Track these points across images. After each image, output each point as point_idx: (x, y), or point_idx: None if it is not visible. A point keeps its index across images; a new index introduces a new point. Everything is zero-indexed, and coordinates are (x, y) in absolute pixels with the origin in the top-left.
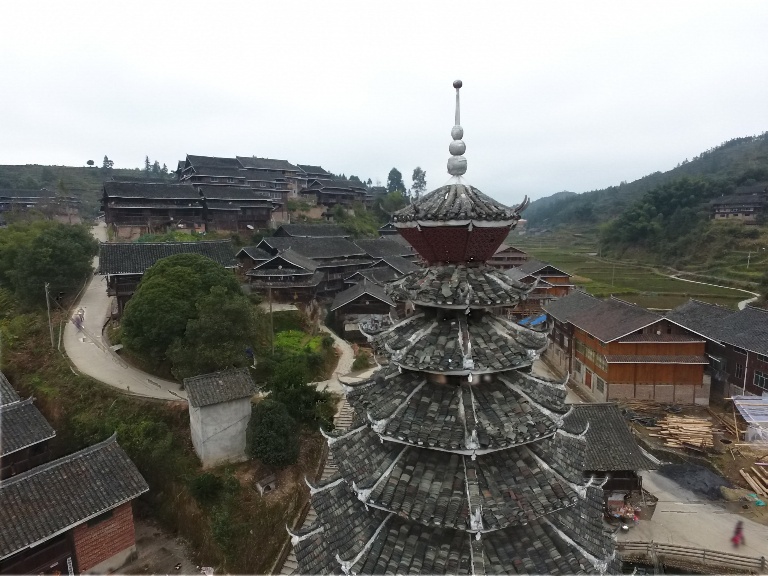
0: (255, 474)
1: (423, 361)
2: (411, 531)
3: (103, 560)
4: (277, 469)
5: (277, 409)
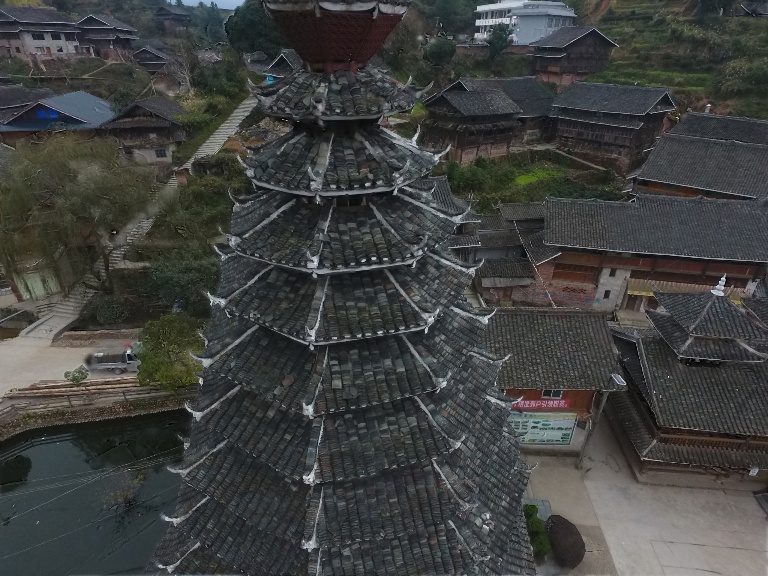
0: None
1: None
2: None
3: None
4: None
5: None
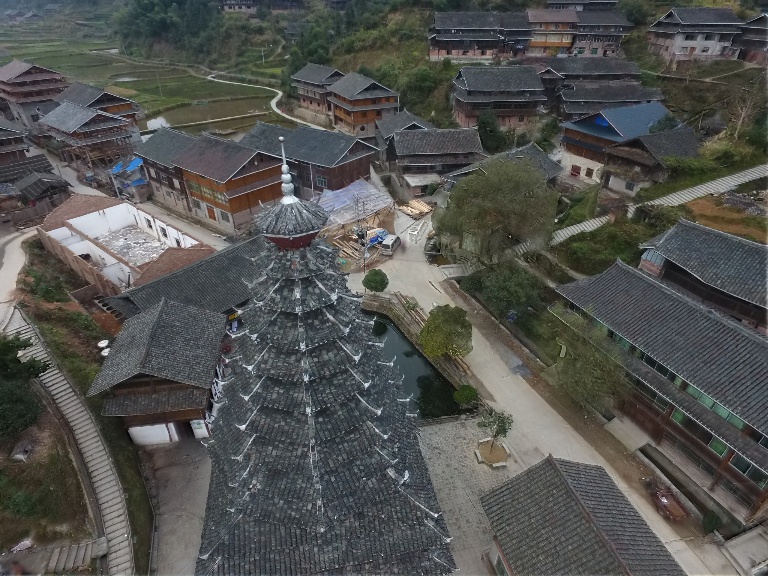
0: None
1: (313, 305)
2: (321, 379)
3: None
4: (14, 434)
5: None
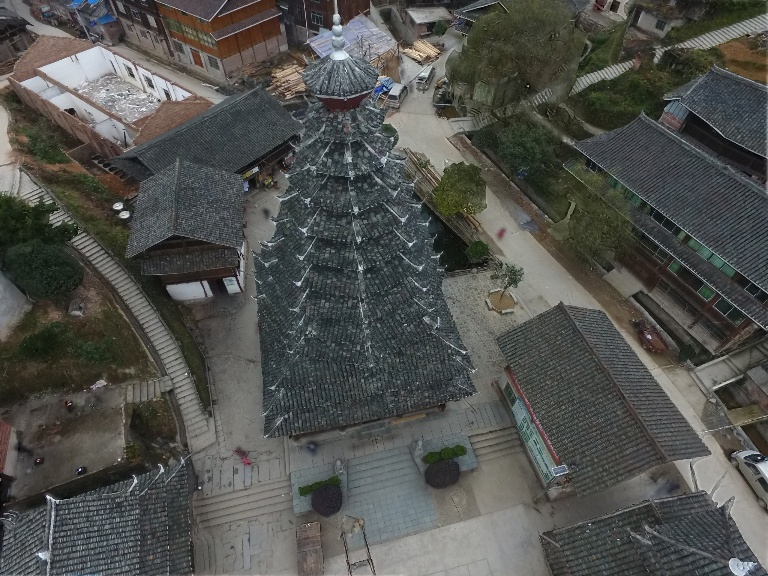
0: (58, 308)
1: (365, 169)
2: (369, 240)
3: (6, 454)
4: None
5: (38, 247)
